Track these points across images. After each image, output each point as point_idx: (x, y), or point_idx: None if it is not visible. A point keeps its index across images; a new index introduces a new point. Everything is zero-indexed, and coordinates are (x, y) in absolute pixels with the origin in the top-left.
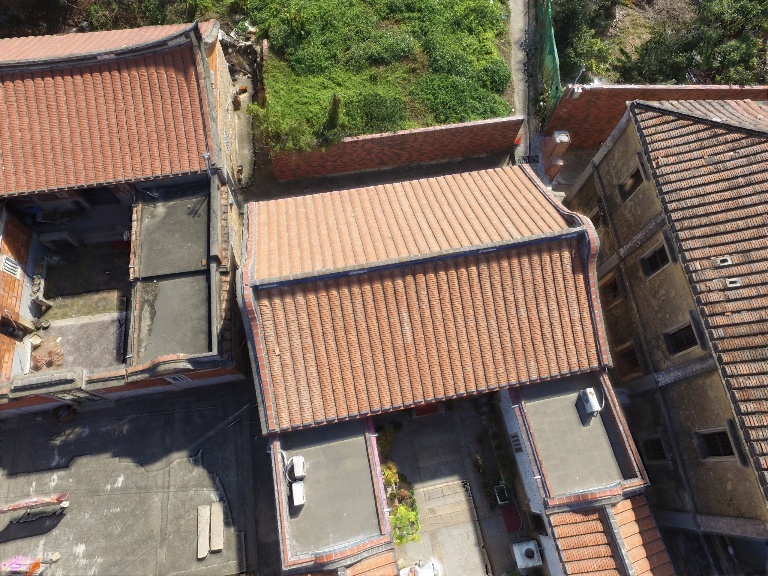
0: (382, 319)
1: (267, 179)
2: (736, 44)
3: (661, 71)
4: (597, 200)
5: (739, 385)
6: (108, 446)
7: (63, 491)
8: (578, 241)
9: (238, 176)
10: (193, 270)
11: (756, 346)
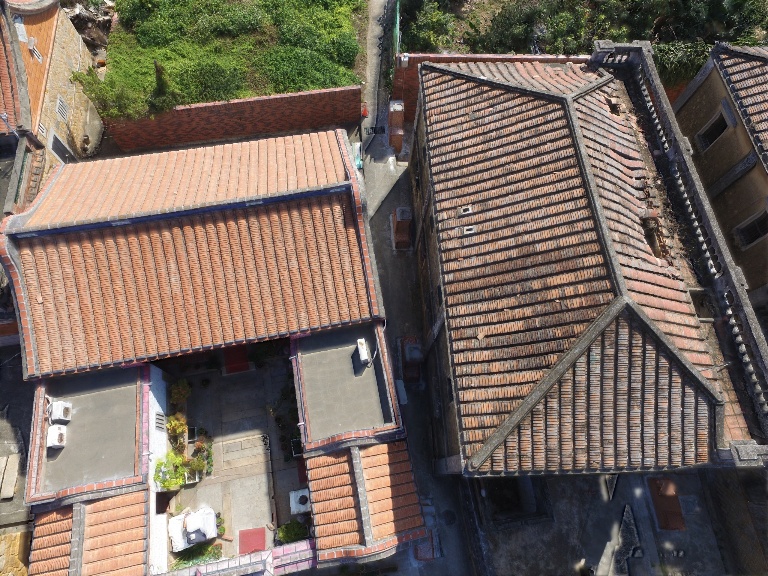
0: (149, 270)
1: (113, 149)
2: (566, 15)
3: (502, 43)
4: None
5: (456, 325)
6: None
7: None
8: (349, 196)
9: (83, 145)
10: None
11: (476, 288)
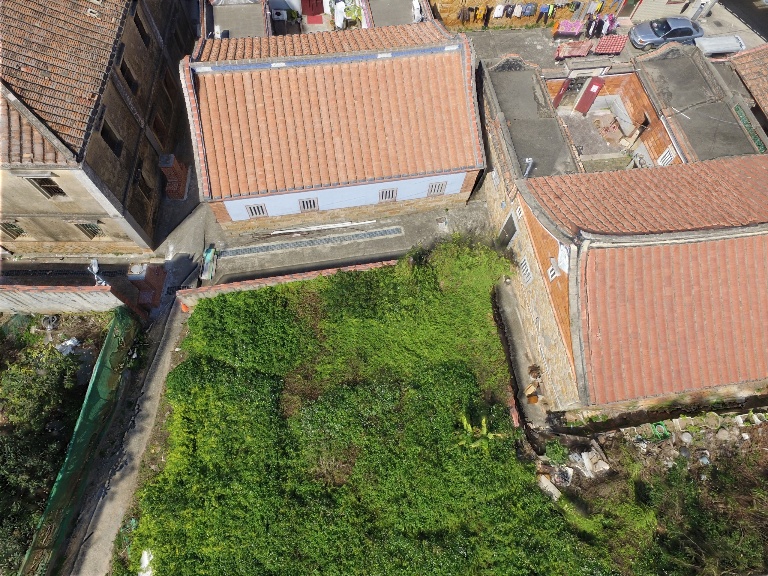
0: None
1: None
2: None
3: None
4: None
5: None
6: None
7: None
8: None
9: None
10: (516, 120)
11: None
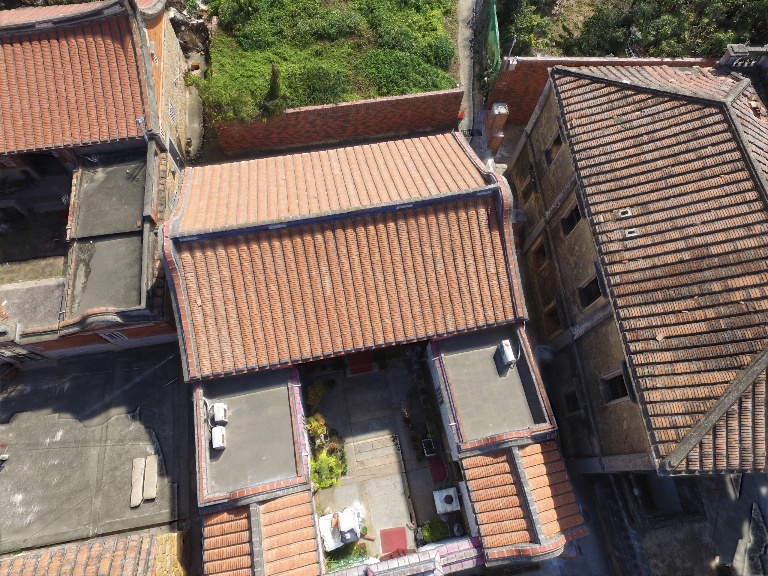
0: (302, 272)
1: (215, 151)
2: (669, 18)
3: (599, 46)
4: (529, 167)
5: (630, 327)
6: (48, 403)
7: (3, 445)
8: (494, 199)
9: (186, 148)
10: (128, 231)
11: (648, 290)
